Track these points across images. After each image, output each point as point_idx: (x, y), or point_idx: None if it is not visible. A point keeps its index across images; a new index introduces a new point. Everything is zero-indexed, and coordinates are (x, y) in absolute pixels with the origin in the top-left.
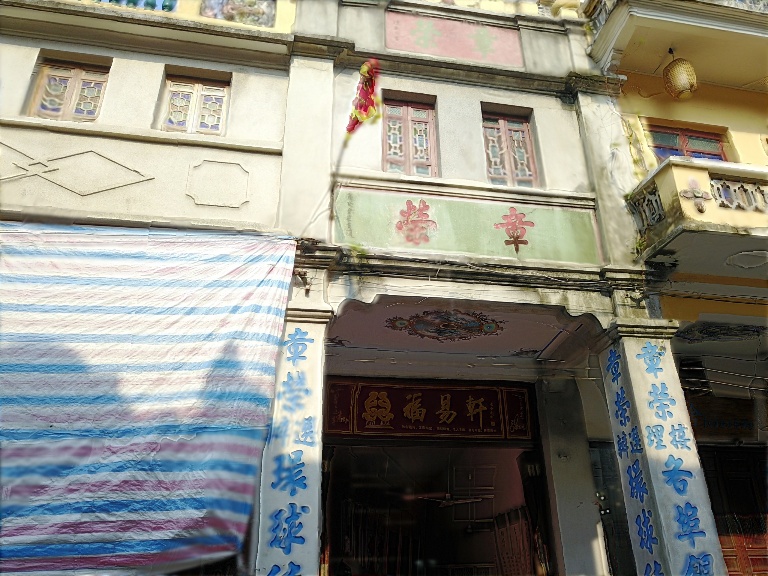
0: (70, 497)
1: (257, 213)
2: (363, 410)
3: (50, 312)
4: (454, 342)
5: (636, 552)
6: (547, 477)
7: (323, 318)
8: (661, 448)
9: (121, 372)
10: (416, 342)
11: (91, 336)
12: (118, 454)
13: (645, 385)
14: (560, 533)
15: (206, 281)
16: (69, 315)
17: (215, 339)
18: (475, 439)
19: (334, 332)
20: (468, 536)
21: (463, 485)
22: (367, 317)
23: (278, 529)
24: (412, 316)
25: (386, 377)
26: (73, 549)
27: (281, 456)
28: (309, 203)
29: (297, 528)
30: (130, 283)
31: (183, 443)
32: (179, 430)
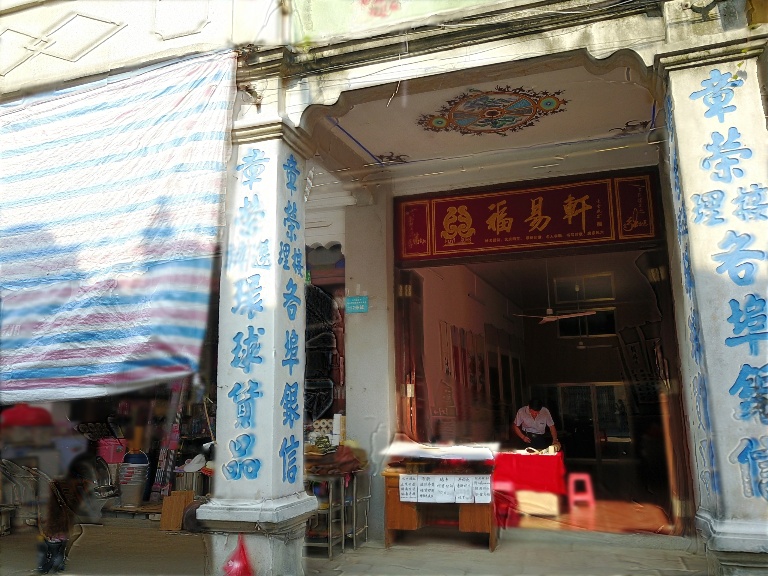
0: (54, 331)
1: (218, 32)
2: (441, 228)
3: (43, 177)
4: (519, 132)
5: (689, 363)
6: (670, 280)
7: (275, 133)
8: (714, 222)
9: (97, 220)
10: (476, 141)
11: (73, 192)
12: (87, 292)
13: (699, 136)
14: (678, 345)
15: (155, 119)
16: (55, 176)
17: (163, 175)
18: (575, 245)
19: (380, 148)
20: (580, 353)
21: (568, 298)
22: (392, 123)
23: (236, 350)
24: (441, 110)
25: (461, 188)
26: (63, 372)
27: (239, 282)
28: (261, 4)
29: (258, 349)
30: (96, 136)
31: (137, 278)
32: (132, 266)
